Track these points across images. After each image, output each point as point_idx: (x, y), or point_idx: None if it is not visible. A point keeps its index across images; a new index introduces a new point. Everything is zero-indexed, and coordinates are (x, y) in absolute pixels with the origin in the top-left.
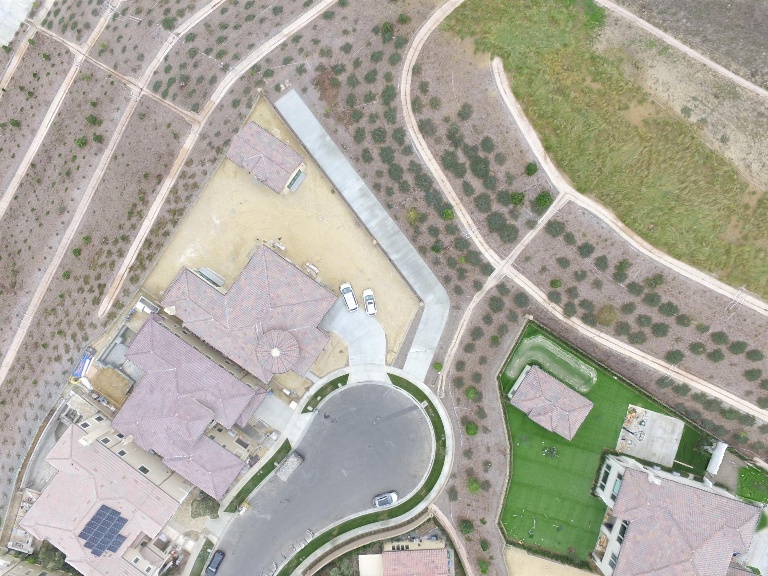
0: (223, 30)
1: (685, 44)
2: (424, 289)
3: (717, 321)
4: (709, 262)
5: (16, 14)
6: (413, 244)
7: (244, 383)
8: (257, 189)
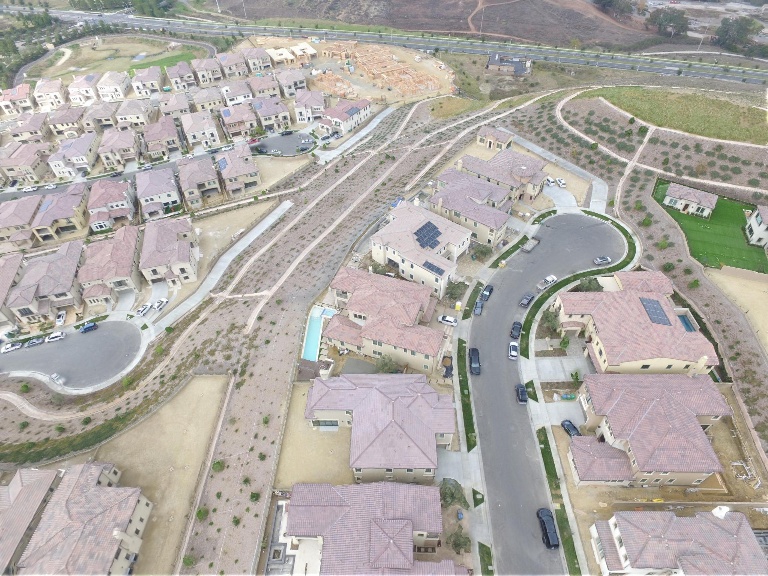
0: None
1: (681, 87)
2: None
3: (765, 159)
4: (741, 136)
5: (331, 156)
6: (577, 166)
7: None
8: (489, 151)
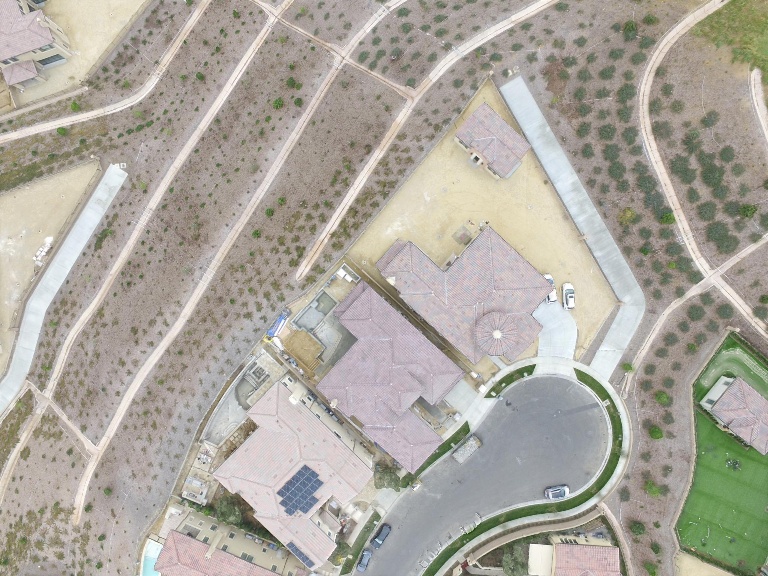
0: (441, 9)
1: None
2: (622, 289)
3: None
4: None
5: None
6: (618, 244)
7: (452, 361)
8: (471, 171)
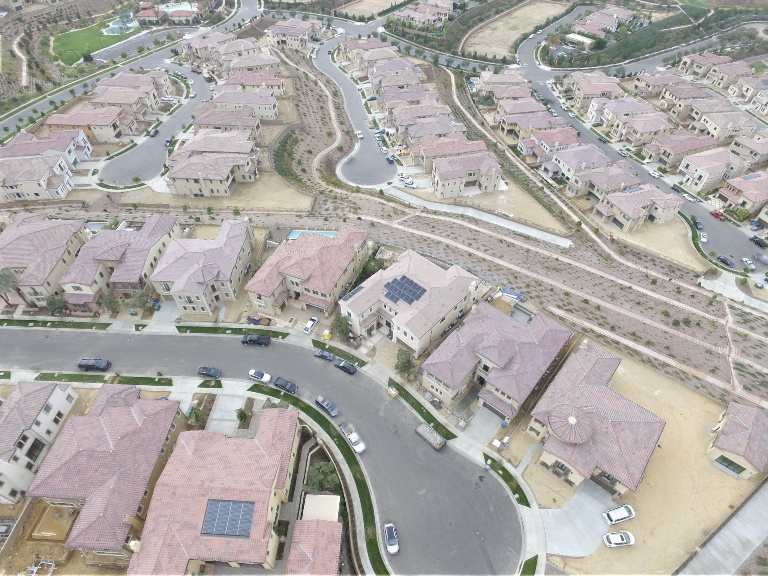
0: None
1: None
2: None
3: None
4: None
5: (727, 292)
6: None
7: None
8: (701, 430)
